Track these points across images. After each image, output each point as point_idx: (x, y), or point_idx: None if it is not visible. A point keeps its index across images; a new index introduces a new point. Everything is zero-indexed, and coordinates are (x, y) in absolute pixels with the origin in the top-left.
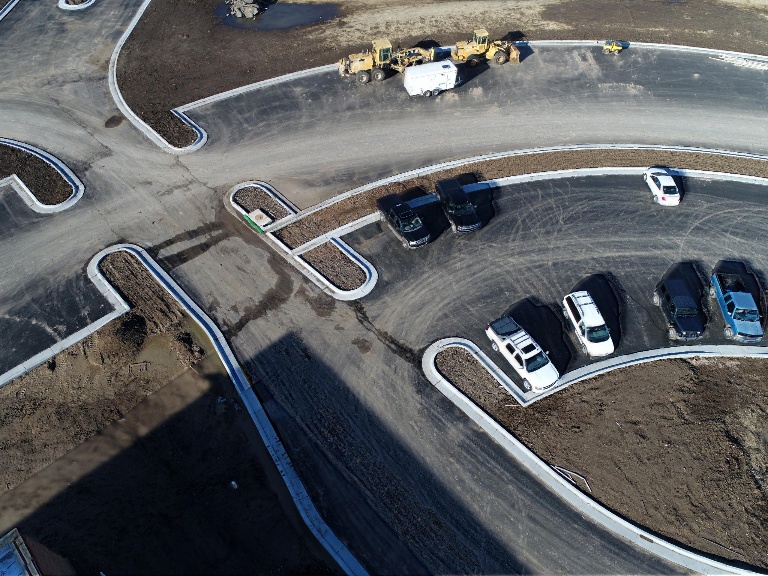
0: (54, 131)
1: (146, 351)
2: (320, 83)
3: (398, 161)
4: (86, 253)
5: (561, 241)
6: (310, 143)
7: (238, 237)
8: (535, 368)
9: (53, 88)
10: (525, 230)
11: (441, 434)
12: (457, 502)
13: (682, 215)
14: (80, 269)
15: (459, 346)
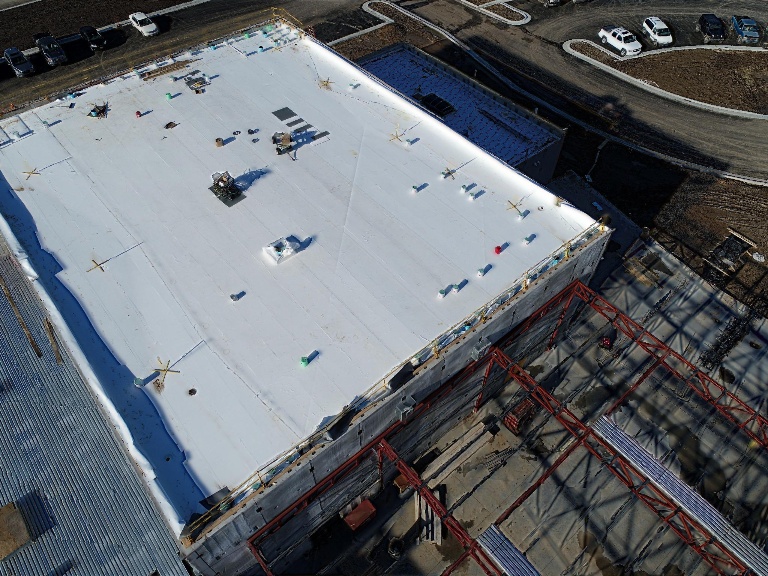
0: None
1: (409, 36)
2: None
3: None
4: (359, 2)
5: (640, 8)
6: None
7: (444, 1)
8: (629, 42)
9: None
10: (618, 3)
11: (577, 68)
12: (589, 87)
13: (716, 1)
14: (358, 8)
15: (583, 41)
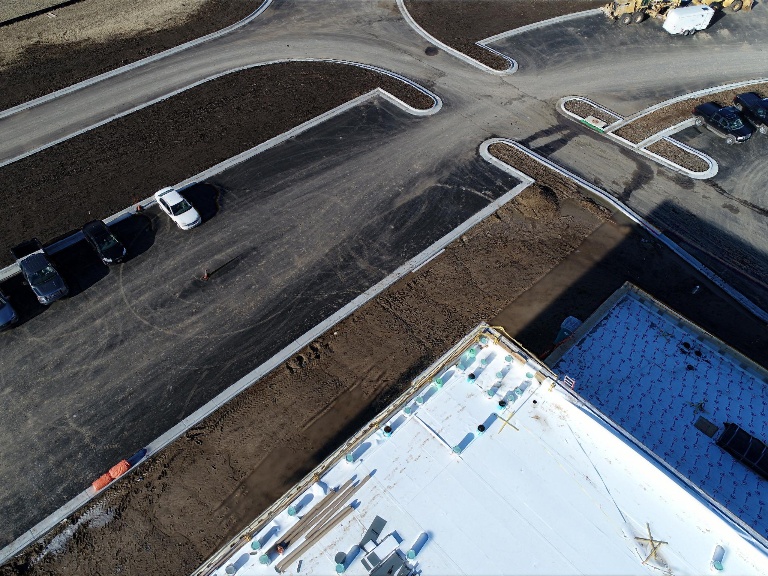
0: (388, 57)
1: (564, 209)
2: (587, 24)
3: (686, 83)
4: (472, 144)
5: None
6: (605, 69)
7: (585, 135)
8: None
9: (365, 25)
10: None
11: None
12: None
13: None
14: (474, 154)
15: None
